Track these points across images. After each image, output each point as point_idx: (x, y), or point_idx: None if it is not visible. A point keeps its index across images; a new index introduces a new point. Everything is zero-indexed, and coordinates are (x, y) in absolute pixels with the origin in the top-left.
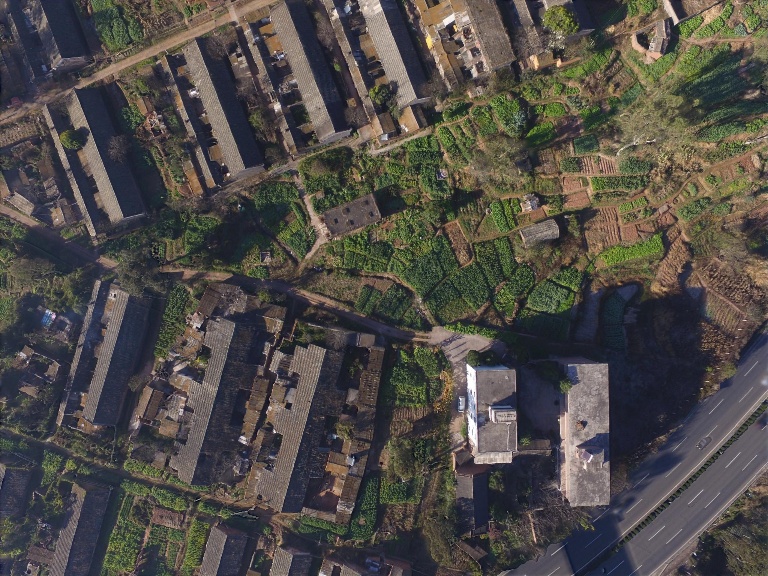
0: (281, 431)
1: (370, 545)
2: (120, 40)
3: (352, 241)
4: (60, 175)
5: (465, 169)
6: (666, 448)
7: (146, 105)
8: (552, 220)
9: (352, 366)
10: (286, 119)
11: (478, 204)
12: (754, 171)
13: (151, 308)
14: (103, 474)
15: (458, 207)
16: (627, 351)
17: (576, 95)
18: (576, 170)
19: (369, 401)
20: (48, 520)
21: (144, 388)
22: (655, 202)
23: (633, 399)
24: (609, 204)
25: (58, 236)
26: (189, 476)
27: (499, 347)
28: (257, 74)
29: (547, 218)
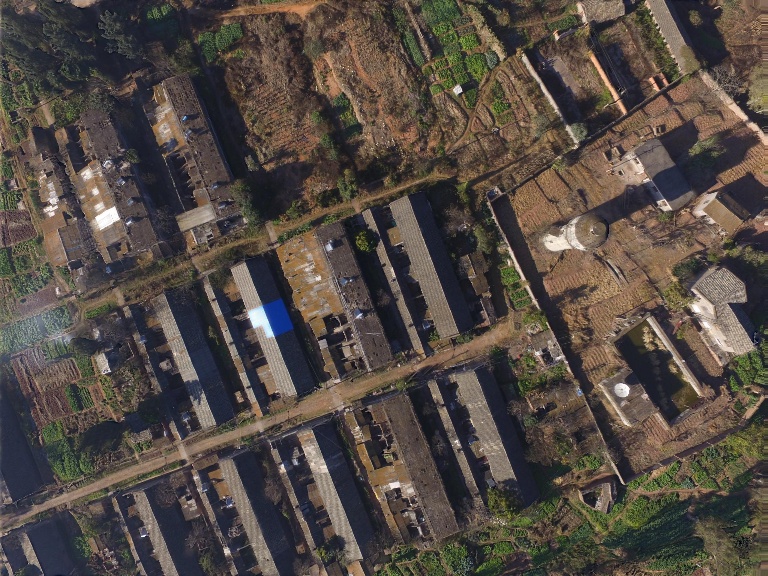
0: None
1: None
2: (71, 474)
3: None
4: None
5: None
6: None
7: (97, 545)
8: None
9: None
10: (235, 565)
11: None
12: None
13: None
14: None
15: None
16: None
17: (524, 536)
18: None
19: None
20: None
21: None
22: None
23: None
24: None
25: None
26: None
27: None
28: None
29: None
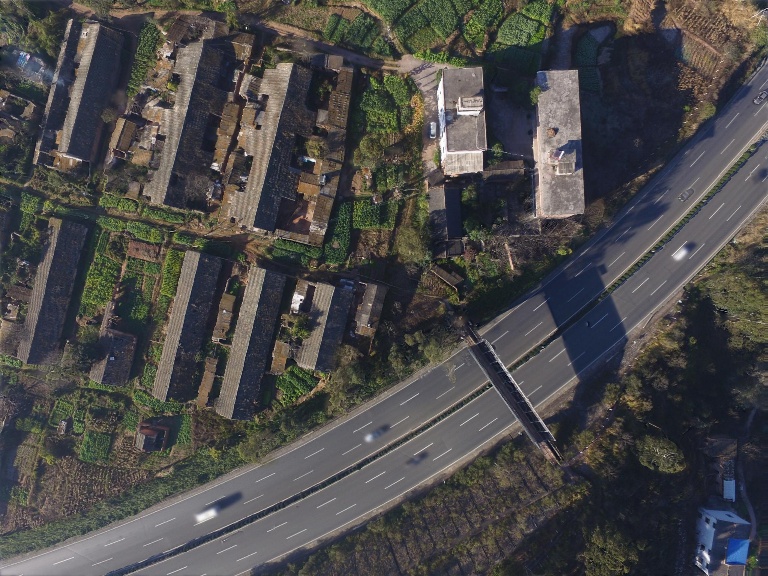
0: (252, 152)
1: (345, 270)
2: None
3: None
4: None
5: None
6: (647, 201)
7: None
8: None
9: (321, 87)
10: None
11: None
12: None
13: (123, 48)
14: (79, 212)
15: None
16: (602, 93)
17: None
18: None
19: (339, 122)
20: (26, 258)
21: (117, 122)
22: None
23: (610, 141)
24: None
25: None
26: (162, 197)
27: None
28: None
29: None
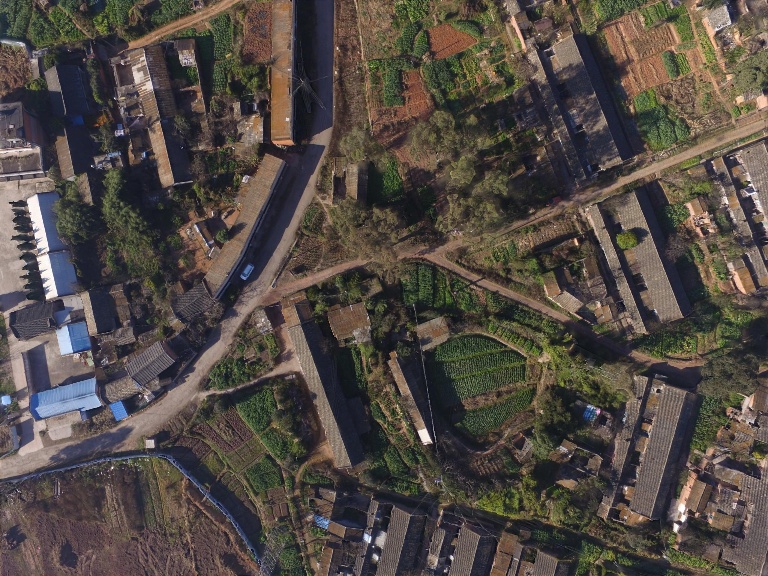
0: None
1: None
2: (668, 140)
3: None
4: None
5: None
6: None
7: (701, 206)
8: None
9: None
10: None
11: None
12: None
13: None
14: (643, 564)
15: None
16: None
17: None
18: None
19: None
20: None
21: None
22: None
23: None
24: None
25: (590, 331)
26: (756, 570)
27: None
28: None
29: None
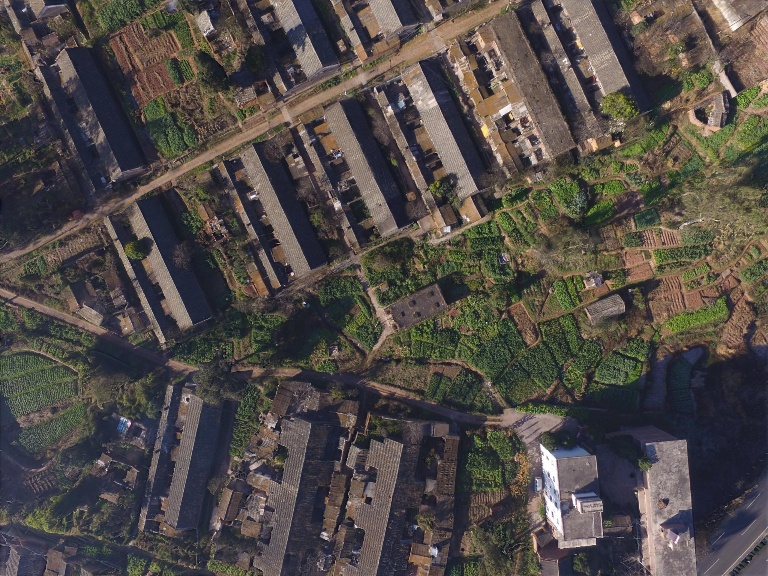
0: (363, 526)
1: None
2: (176, 148)
3: (418, 330)
4: (125, 283)
5: (527, 252)
6: None
7: (207, 211)
8: (617, 295)
9: (428, 457)
10: (347, 217)
11: (541, 284)
12: None
13: (223, 408)
14: (187, 575)
15: (522, 289)
16: (696, 414)
17: (635, 172)
18: (638, 245)
19: (447, 490)
20: None
21: (223, 489)
22: (718, 267)
23: (706, 462)
24: (672, 273)
25: (126, 342)
26: None
27: (571, 424)
28: (313, 172)
29: (611, 292)
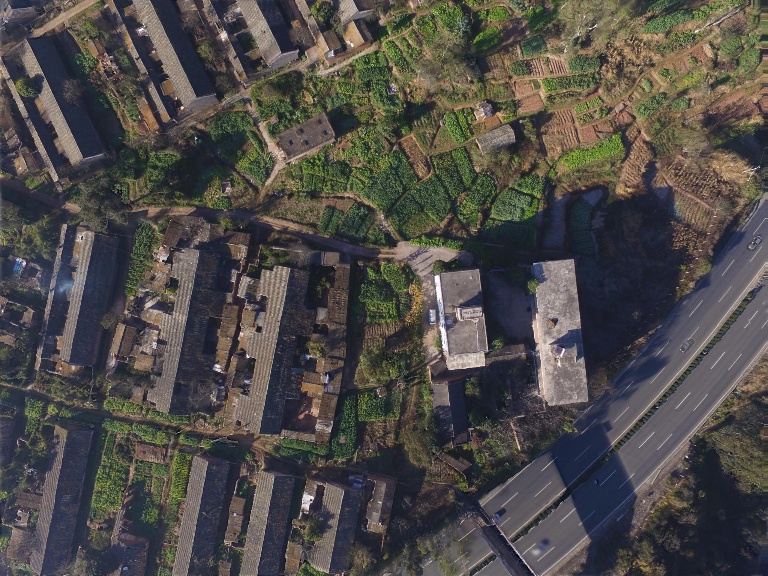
0: (254, 355)
1: (353, 464)
2: None
3: (310, 163)
4: (20, 126)
5: (415, 81)
6: (648, 354)
7: (97, 47)
8: (507, 125)
9: (319, 285)
10: (233, 46)
11: (432, 116)
12: (707, 61)
13: (119, 248)
14: (84, 416)
15: (412, 121)
16: (598, 256)
17: None
18: (526, 73)
19: (339, 319)
20: (34, 465)
21: (117, 326)
22: (610, 101)
23: (608, 304)
24: (564, 106)
25: (23, 187)
26: (166, 406)
27: (466, 258)
28: (203, 8)
29: (502, 125)
